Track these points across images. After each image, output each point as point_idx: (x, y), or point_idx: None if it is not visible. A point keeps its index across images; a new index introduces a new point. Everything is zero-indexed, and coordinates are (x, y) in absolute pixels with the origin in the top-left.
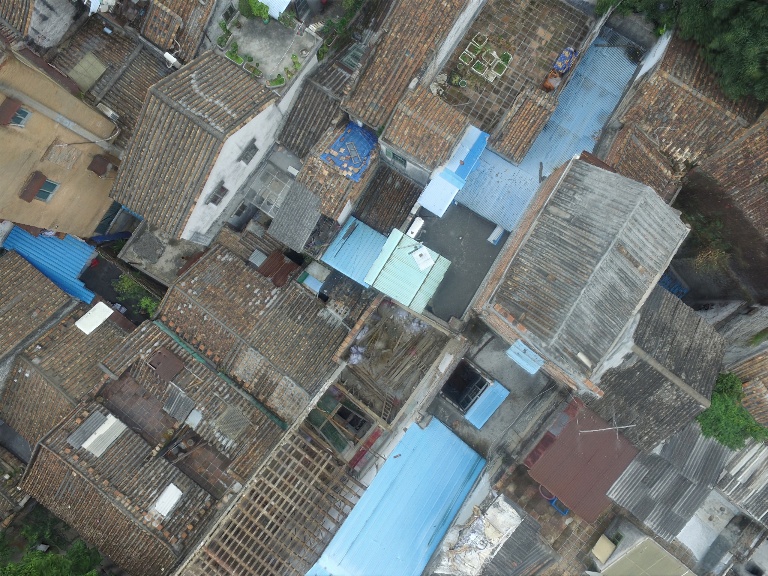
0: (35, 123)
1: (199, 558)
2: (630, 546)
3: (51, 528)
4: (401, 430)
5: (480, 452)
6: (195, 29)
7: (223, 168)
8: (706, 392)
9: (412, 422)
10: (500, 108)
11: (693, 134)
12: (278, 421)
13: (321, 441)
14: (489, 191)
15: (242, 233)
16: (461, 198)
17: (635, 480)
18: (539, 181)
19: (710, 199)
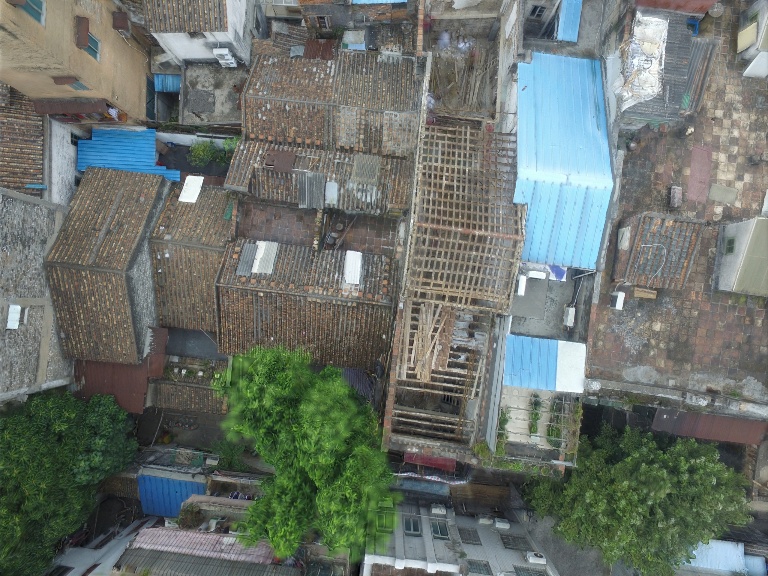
0: None
1: (417, 236)
2: None
3: None
4: (509, 104)
5: None
6: None
7: None
8: None
9: None
10: None
11: None
12: None
13: None
14: None
15: (271, 37)
16: None
17: None
18: None
19: None
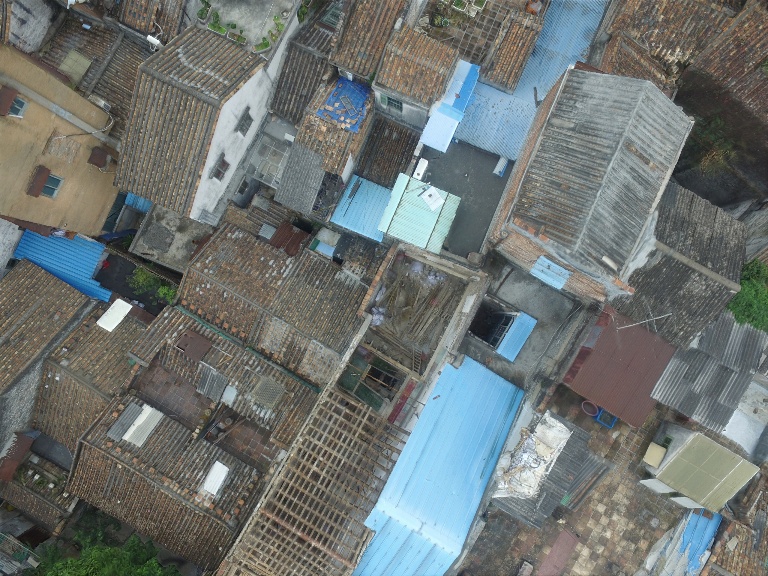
0: (32, 114)
1: (258, 520)
2: (681, 445)
3: (102, 530)
4: (435, 378)
5: (517, 384)
6: (173, 8)
7: (222, 139)
8: (734, 277)
9: (445, 365)
10: (486, 42)
11: (681, 33)
12: (312, 387)
13: (357, 402)
14: (488, 124)
15: (248, 209)
16: (461, 135)
17: (677, 377)
18: (536, 106)
19: (707, 98)
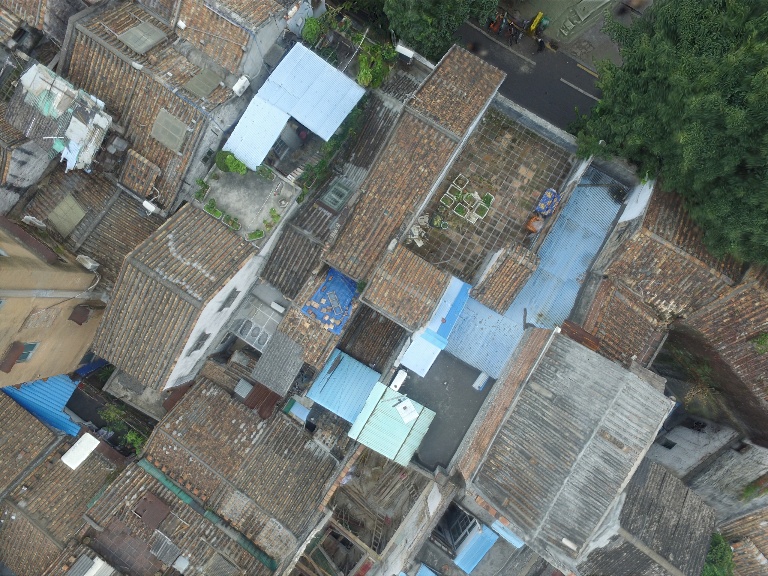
0: (10, 306)
1: None
2: None
3: None
4: (391, 567)
5: None
6: (173, 177)
7: (203, 324)
8: (694, 574)
9: None
10: (483, 249)
11: (678, 288)
12: (266, 559)
13: (311, 573)
14: (473, 338)
15: (227, 364)
16: None
17: None
18: (523, 328)
19: (697, 345)
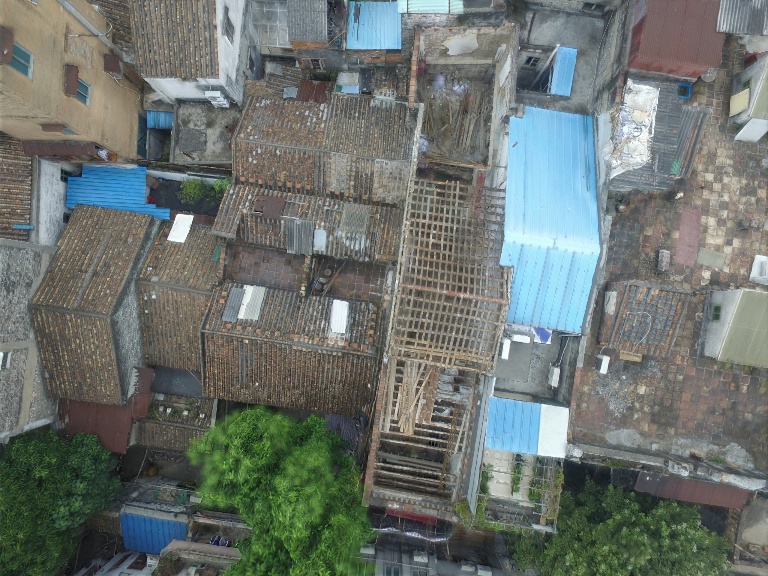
0: (44, 2)
1: (401, 297)
2: (762, 72)
3: None
4: (501, 154)
5: None
6: None
7: None
8: None
9: None
10: None
11: None
12: None
13: None
14: None
15: (265, 78)
16: None
17: (734, 3)
18: None
19: None
